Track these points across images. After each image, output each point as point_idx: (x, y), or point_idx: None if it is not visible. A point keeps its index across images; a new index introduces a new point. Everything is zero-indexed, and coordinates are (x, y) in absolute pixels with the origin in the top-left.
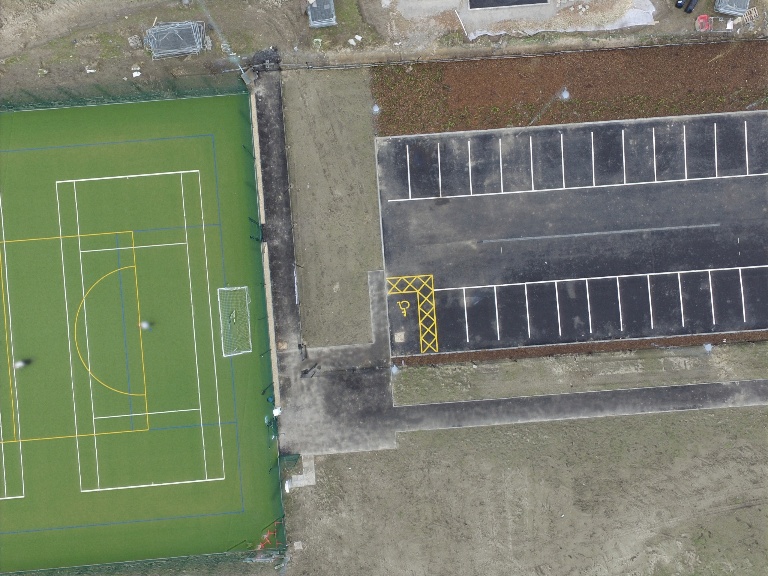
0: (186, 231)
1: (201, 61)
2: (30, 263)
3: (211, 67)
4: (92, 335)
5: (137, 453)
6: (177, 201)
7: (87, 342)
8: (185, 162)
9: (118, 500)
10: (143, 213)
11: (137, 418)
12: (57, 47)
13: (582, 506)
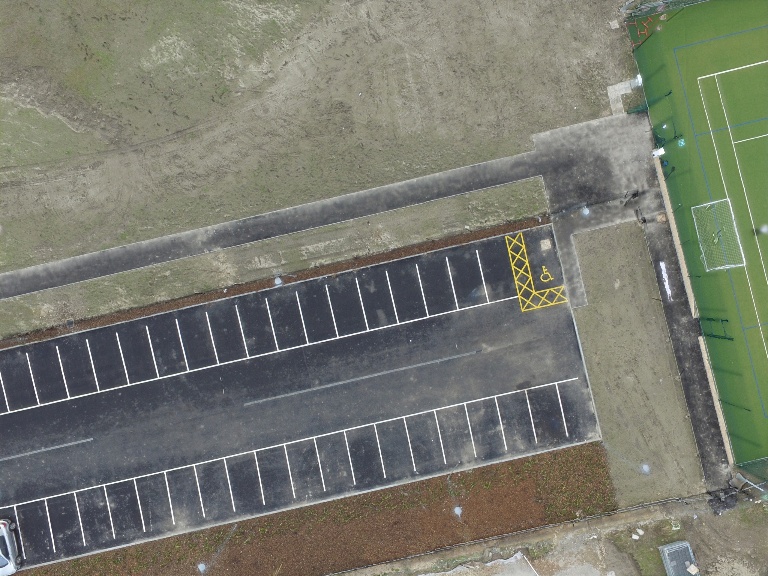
0: None
1: None
2: None
3: None
4: None
5: None
6: None
7: None
8: None
9: None
10: None
11: None
12: None
13: (343, 107)
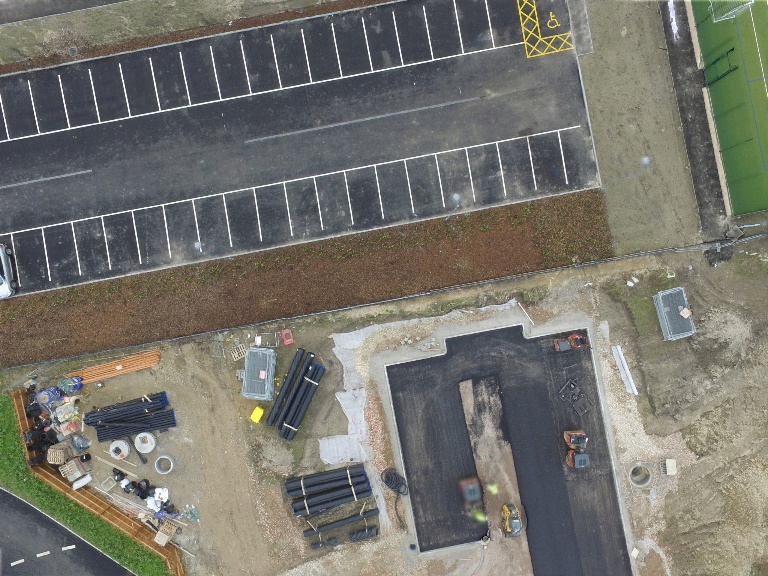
0: None
1: None
2: None
3: None
4: None
5: None
6: None
7: None
8: None
9: None
10: None
11: None
12: None
13: None
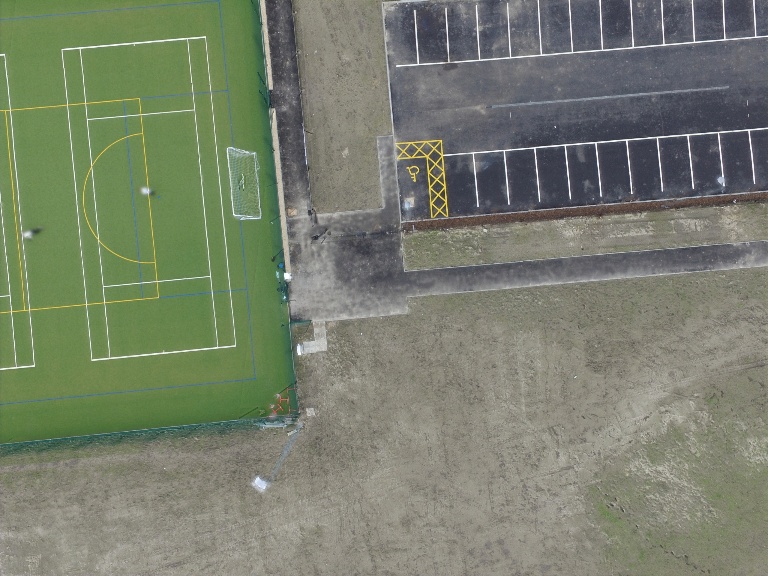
0: (193, 98)
1: None
2: (37, 131)
3: None
4: (100, 203)
5: (147, 321)
6: (184, 68)
7: (95, 210)
8: (191, 28)
9: (129, 368)
10: (150, 80)
11: (147, 286)
12: None
13: (594, 367)
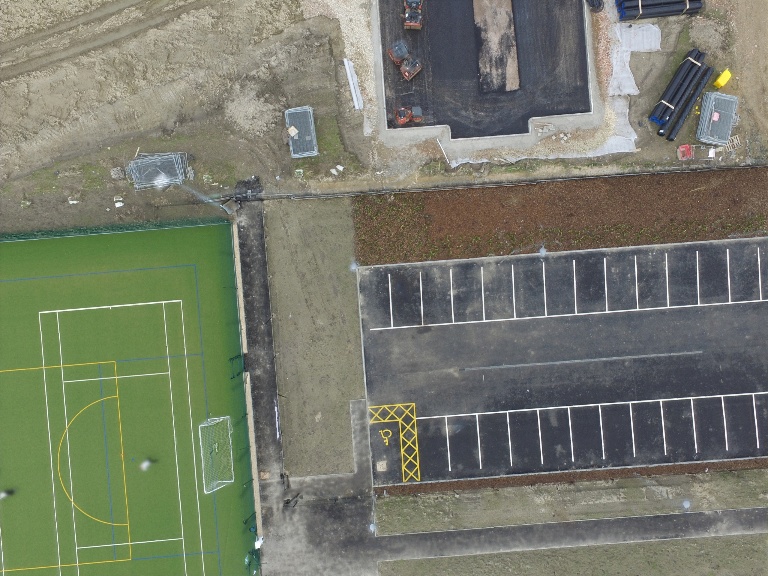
0: (168, 361)
1: (183, 191)
2: (13, 393)
3: (193, 197)
4: (75, 465)
5: None
6: (159, 331)
7: (70, 472)
8: (167, 292)
9: None
10: (126, 343)
11: (120, 548)
12: (40, 178)
13: None
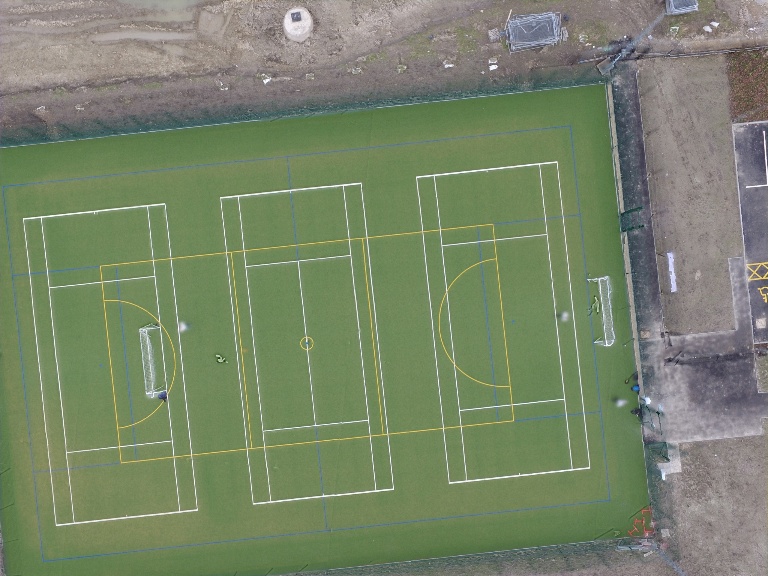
0: (546, 222)
1: (556, 52)
2: (393, 258)
3: (567, 58)
4: (456, 328)
5: (503, 444)
6: (536, 193)
7: (451, 335)
8: (543, 154)
9: (486, 491)
10: (503, 206)
11: (502, 409)
12: (414, 43)
13: None
